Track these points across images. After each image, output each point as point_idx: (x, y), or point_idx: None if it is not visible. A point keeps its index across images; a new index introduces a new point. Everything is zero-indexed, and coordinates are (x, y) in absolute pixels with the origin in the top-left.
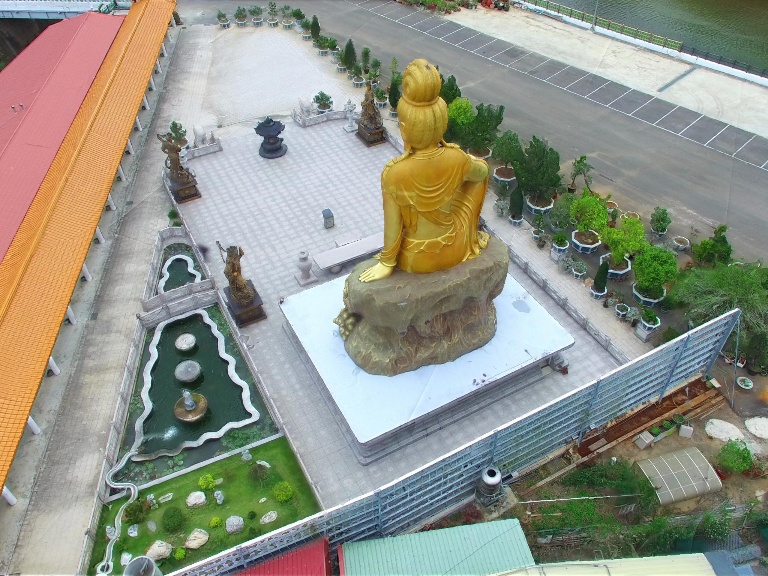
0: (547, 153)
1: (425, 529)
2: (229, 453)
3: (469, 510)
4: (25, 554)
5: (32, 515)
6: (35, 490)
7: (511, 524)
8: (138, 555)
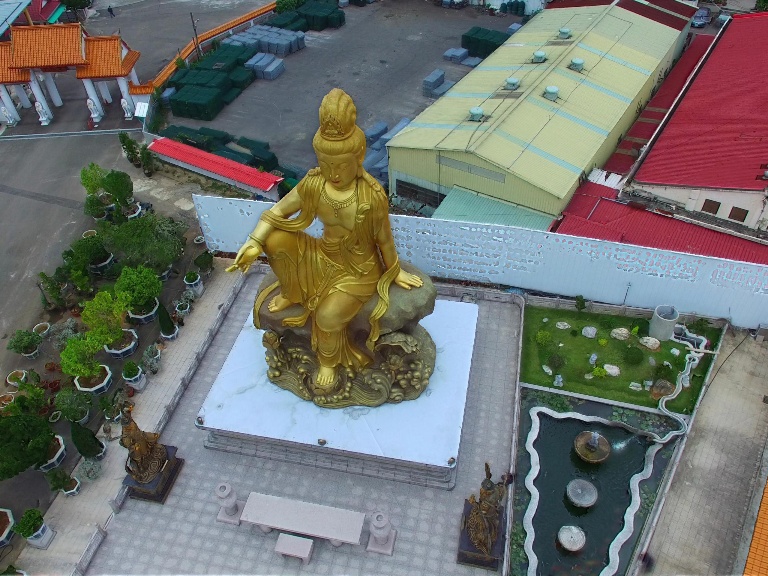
0: (0, 416)
1: (466, 283)
2: (572, 394)
3: (432, 278)
4: (762, 413)
5: (759, 441)
6: (759, 463)
7: (438, 216)
8: (666, 350)
